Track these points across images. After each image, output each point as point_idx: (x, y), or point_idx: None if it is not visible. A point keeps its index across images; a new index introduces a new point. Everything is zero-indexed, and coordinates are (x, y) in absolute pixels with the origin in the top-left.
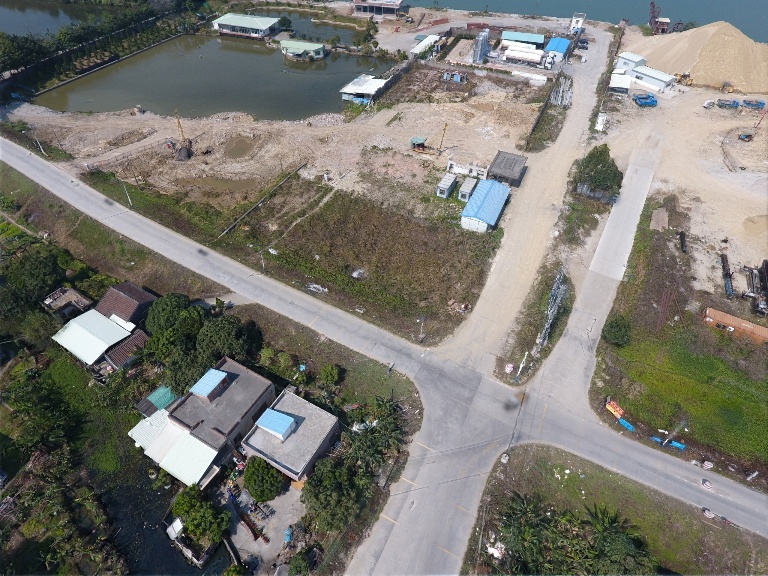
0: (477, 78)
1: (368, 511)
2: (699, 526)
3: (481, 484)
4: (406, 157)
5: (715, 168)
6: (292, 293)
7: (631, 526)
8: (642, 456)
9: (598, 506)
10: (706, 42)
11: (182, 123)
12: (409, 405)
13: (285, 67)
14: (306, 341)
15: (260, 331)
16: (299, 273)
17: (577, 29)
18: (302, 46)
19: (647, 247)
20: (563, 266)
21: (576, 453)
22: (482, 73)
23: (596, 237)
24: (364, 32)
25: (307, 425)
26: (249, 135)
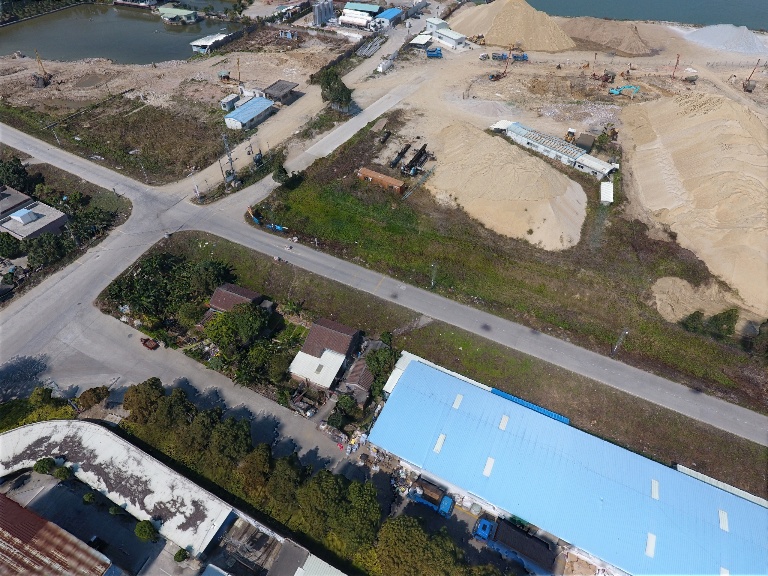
0: (309, 37)
1: (66, 258)
2: (270, 265)
3: (147, 248)
4: (214, 86)
5: (453, 97)
6: (75, 158)
7: (234, 269)
8: (259, 236)
9: (218, 260)
10: (500, 11)
11: (51, 64)
12: (123, 214)
13: (164, 30)
14: (71, 183)
15: (44, 179)
16: (90, 150)
17: (418, 3)
18: (176, 12)
19: (356, 140)
20: (255, 135)
21: (216, 234)
22: (314, 33)
23: (325, 135)
24: None
25: (45, 218)
26: (102, 73)
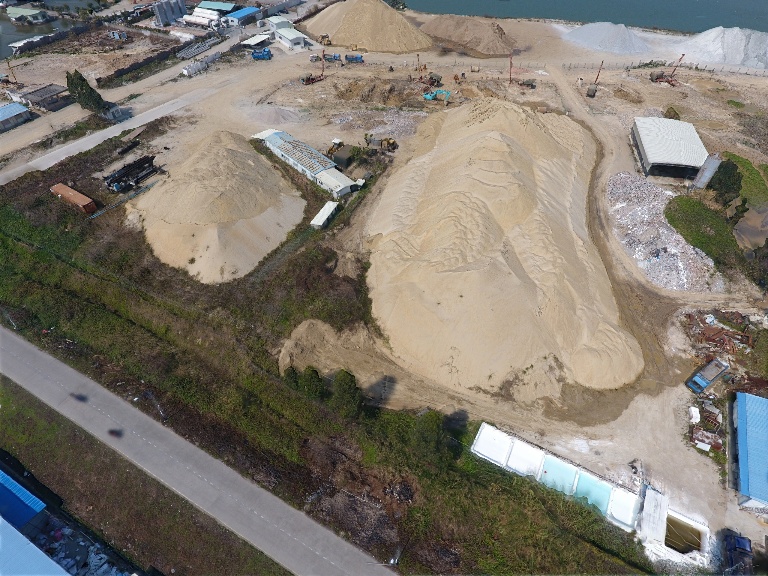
0: (141, 37)
1: None
2: None
3: None
4: None
5: (246, 102)
6: None
7: None
8: None
9: None
10: (350, 8)
11: None
12: None
13: (13, 31)
14: None
15: None
16: None
17: (286, 1)
18: (22, 12)
19: (93, 150)
20: None
21: None
22: (147, 33)
23: (67, 144)
24: (107, 3)
25: None
26: None
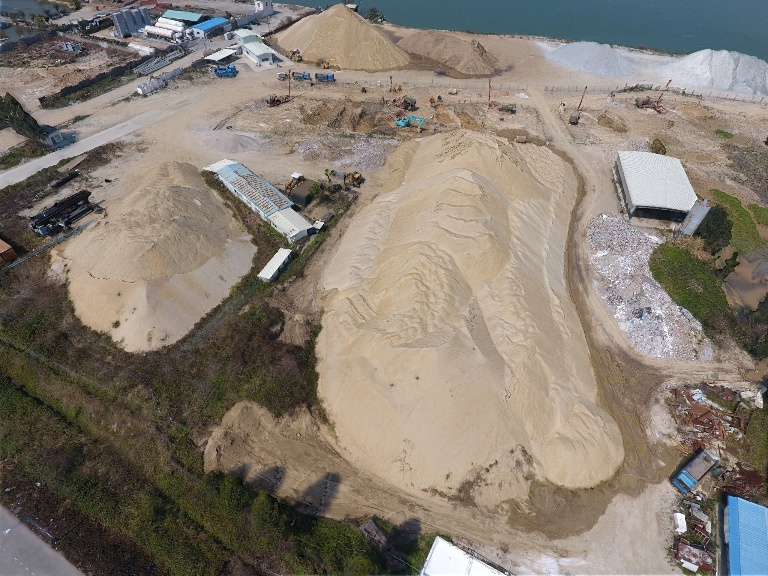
0: (98, 49)
1: None
2: None
3: None
4: None
5: (203, 126)
6: None
7: None
8: None
9: None
10: (323, 23)
11: None
12: None
13: None
14: None
15: None
16: None
17: None
18: None
19: (24, 183)
20: None
21: None
22: (105, 45)
23: None
24: None
25: None
26: None
